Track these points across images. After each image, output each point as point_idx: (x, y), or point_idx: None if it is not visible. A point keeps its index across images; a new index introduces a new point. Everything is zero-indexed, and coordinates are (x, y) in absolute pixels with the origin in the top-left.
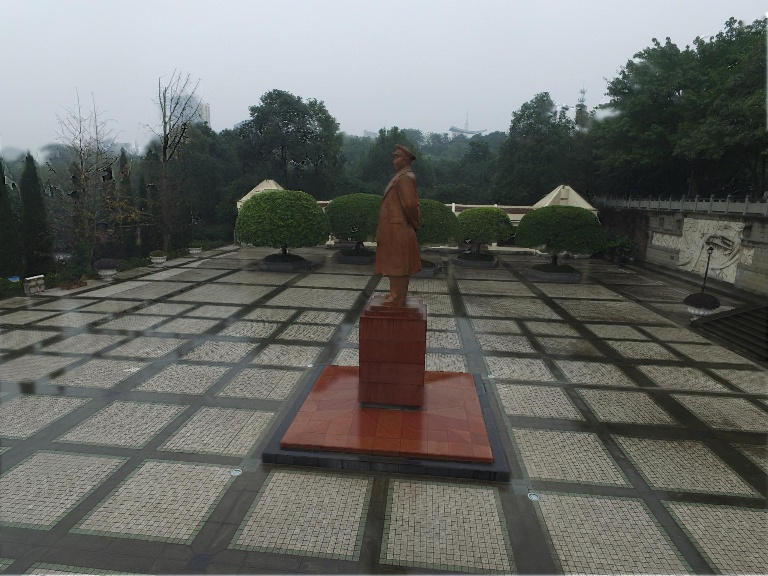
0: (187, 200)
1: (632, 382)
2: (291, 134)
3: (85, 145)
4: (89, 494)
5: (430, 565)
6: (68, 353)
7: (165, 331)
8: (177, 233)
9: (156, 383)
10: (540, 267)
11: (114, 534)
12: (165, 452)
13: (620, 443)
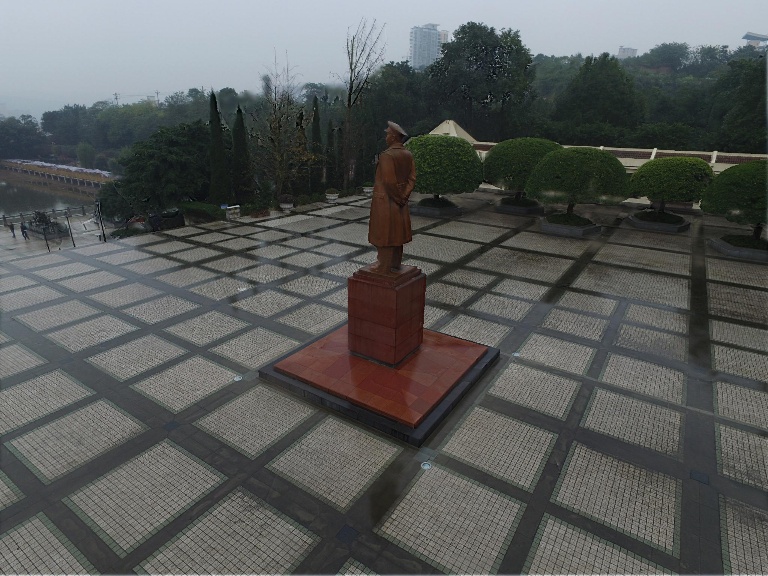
0: (365, 142)
1: (681, 398)
2: (480, 70)
3: (278, 98)
4: (153, 367)
5: (293, 481)
6: (215, 270)
7: (287, 262)
8: (359, 172)
9: (247, 302)
10: (731, 239)
11: (146, 395)
12: (211, 353)
13: (573, 452)
